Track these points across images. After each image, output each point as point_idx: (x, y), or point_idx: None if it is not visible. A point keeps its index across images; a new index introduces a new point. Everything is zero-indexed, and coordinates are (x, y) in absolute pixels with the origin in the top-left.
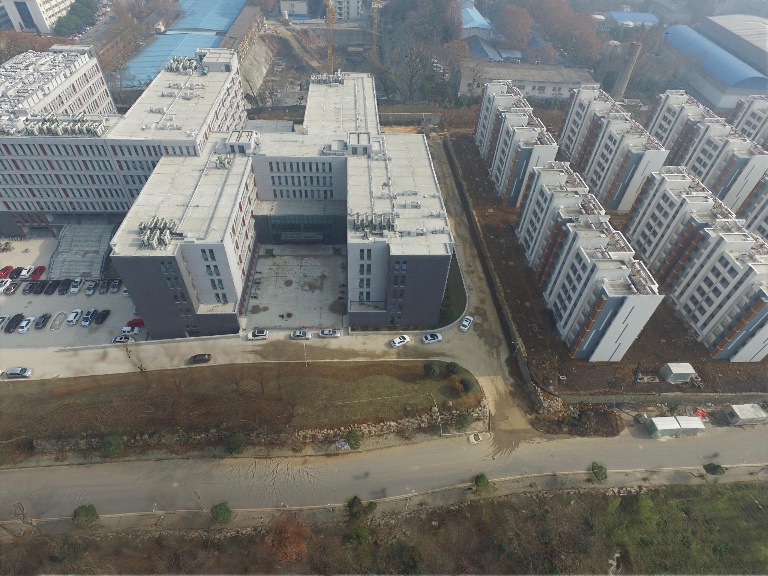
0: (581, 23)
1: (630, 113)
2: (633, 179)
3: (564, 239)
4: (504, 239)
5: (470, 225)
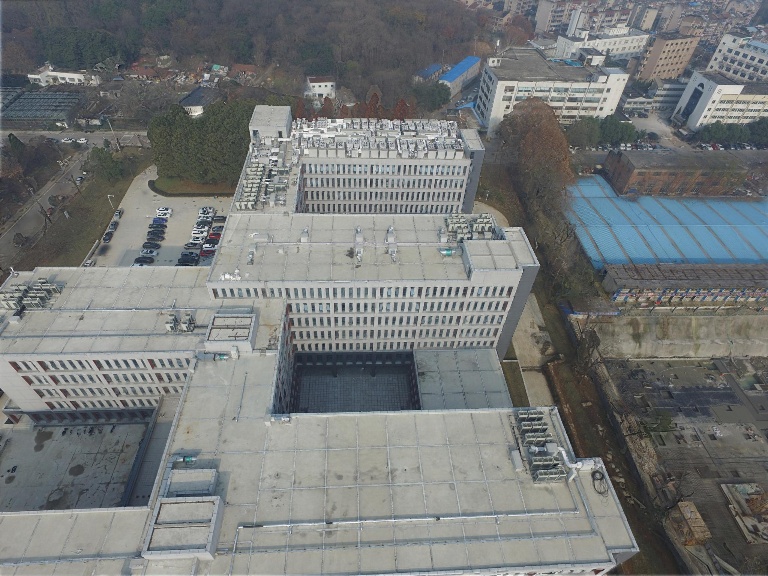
0: None
1: None
2: None
3: None
4: None
5: None
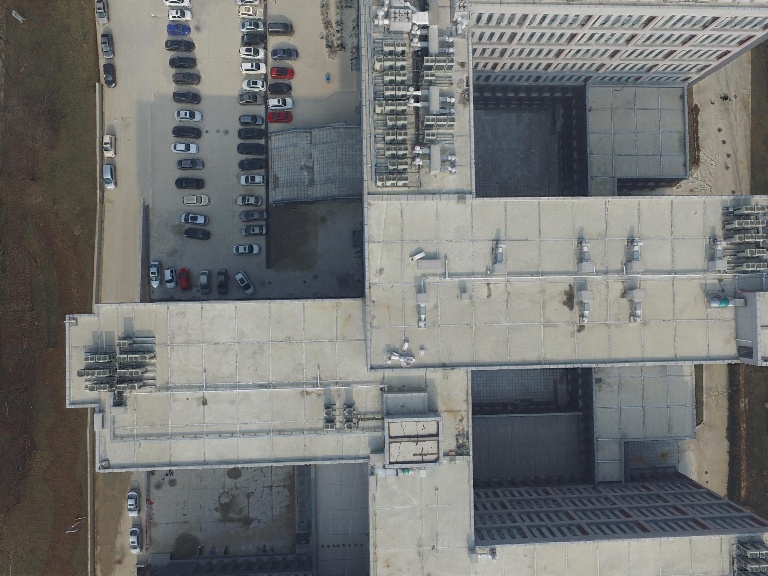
0: None
1: None
2: None
3: None
4: None
5: None
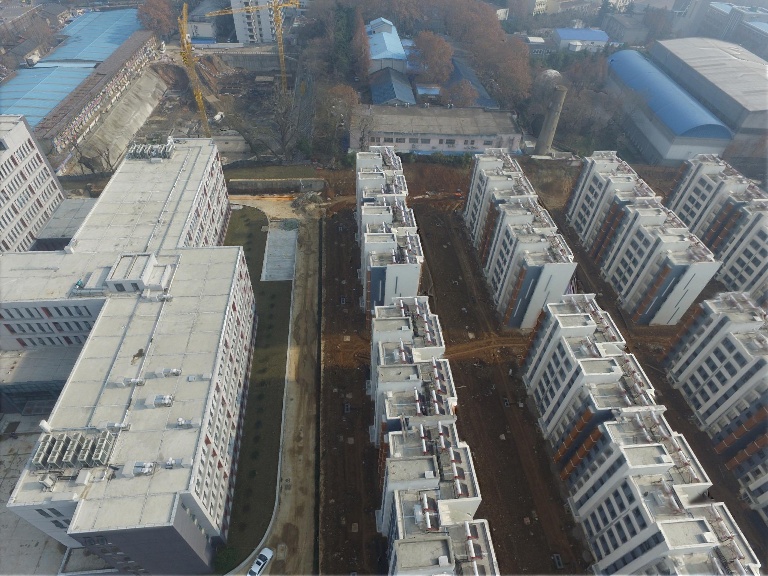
0: (508, 53)
1: (537, 195)
2: (534, 295)
3: (388, 453)
4: (352, 392)
5: (317, 362)
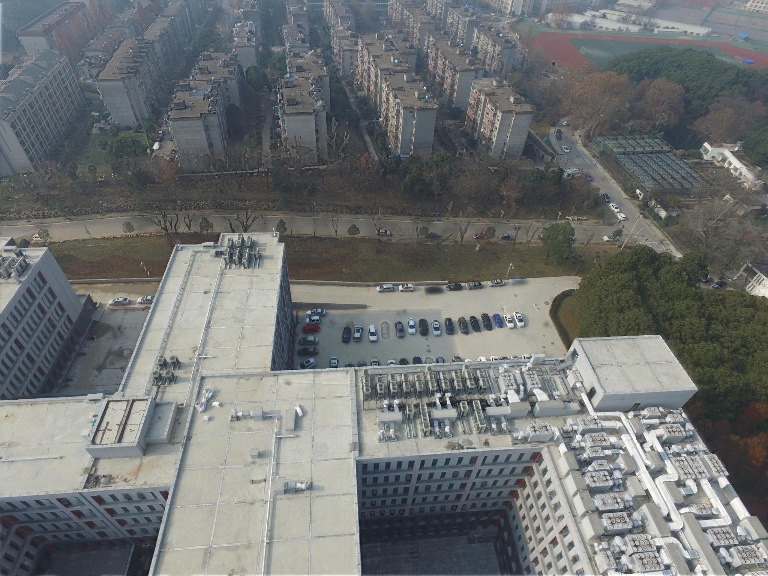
0: None
1: None
2: None
3: None
4: None
5: None
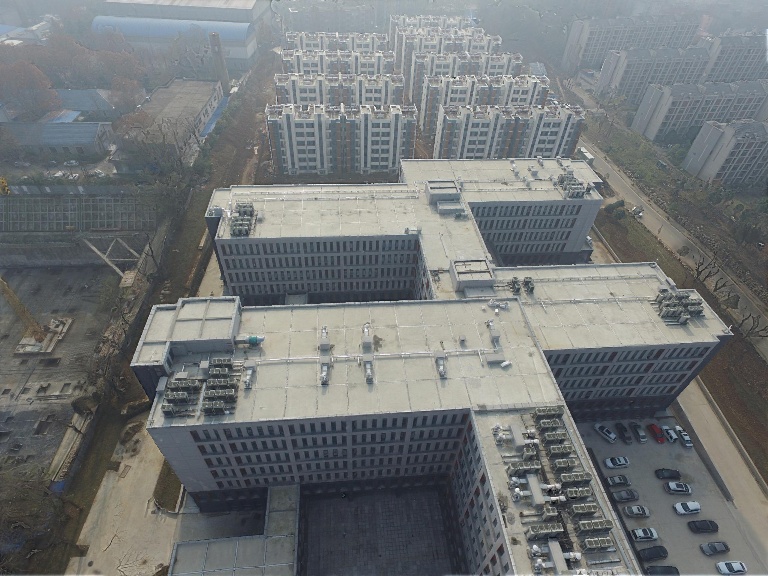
0: (79, 48)
1: None
2: None
3: None
4: None
5: None
